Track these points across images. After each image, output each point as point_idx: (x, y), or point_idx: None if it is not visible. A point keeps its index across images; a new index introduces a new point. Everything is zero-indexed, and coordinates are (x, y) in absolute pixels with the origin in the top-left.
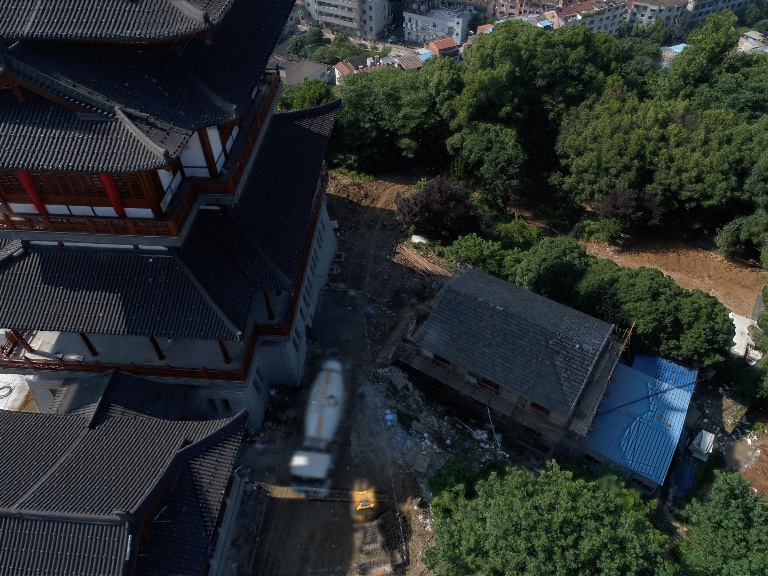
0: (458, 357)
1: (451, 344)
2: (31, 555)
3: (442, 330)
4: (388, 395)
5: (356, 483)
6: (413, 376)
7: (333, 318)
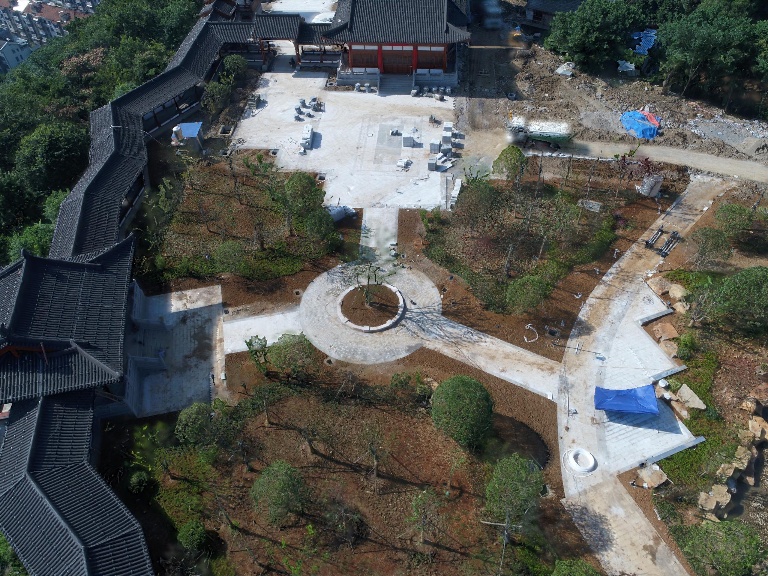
0: (547, 9)
1: (543, 5)
2: (410, 3)
3: (538, 0)
4: (514, 26)
5: (507, 45)
6: (523, 27)
7: (479, 6)
